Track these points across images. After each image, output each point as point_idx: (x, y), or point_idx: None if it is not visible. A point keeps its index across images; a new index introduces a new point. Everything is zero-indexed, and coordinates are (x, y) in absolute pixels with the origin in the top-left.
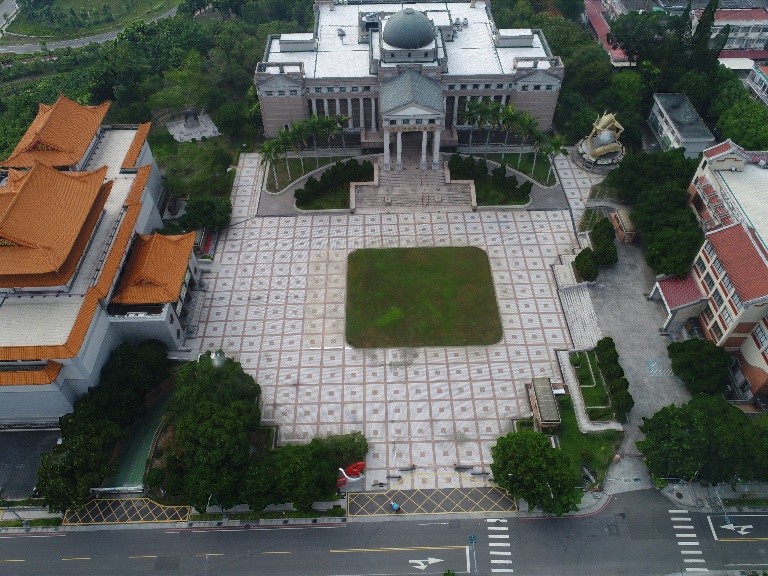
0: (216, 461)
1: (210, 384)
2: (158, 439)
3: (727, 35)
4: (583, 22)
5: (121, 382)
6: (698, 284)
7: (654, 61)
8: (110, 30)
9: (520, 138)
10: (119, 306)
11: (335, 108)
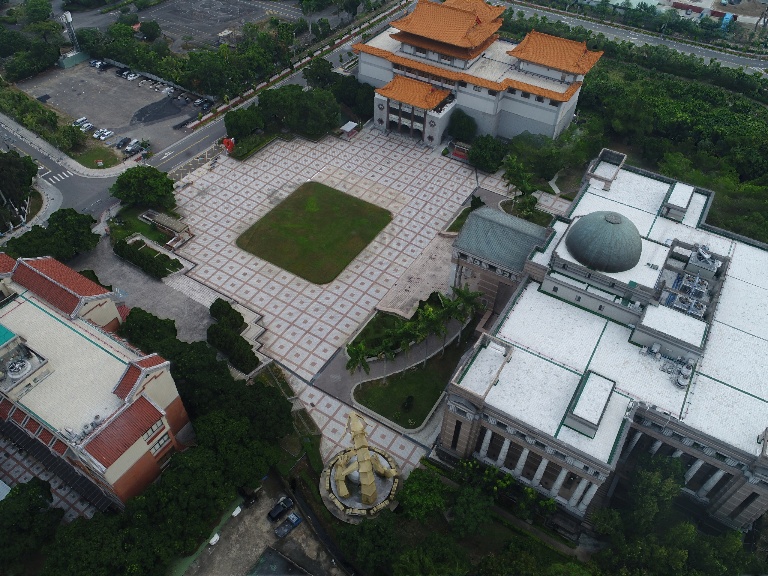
0: None
1: None
2: None
3: None
4: None
5: None
6: None
7: None
8: None
9: None
10: None
11: None
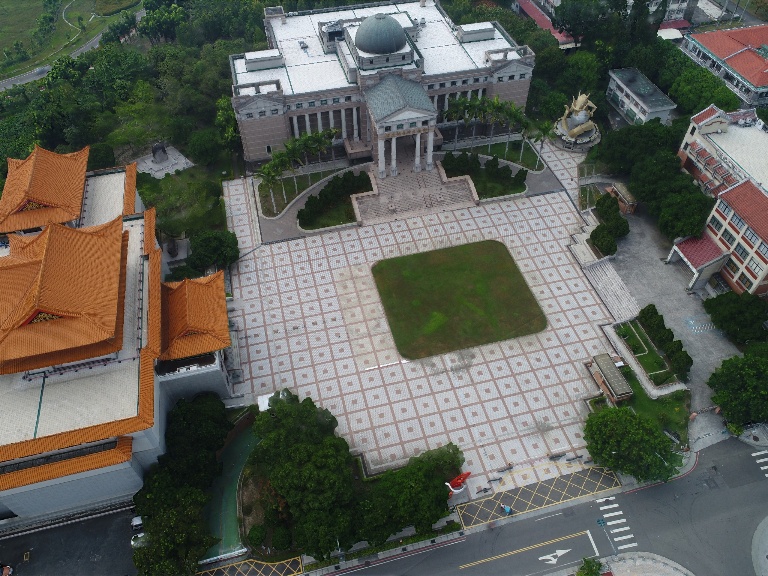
0: (328, 504)
1: (294, 426)
2: (242, 495)
3: (665, 9)
4: (514, 10)
5: (193, 443)
6: (716, 241)
7: (601, 40)
8: (28, 70)
9: (497, 128)
10: (163, 363)
11: (315, 122)
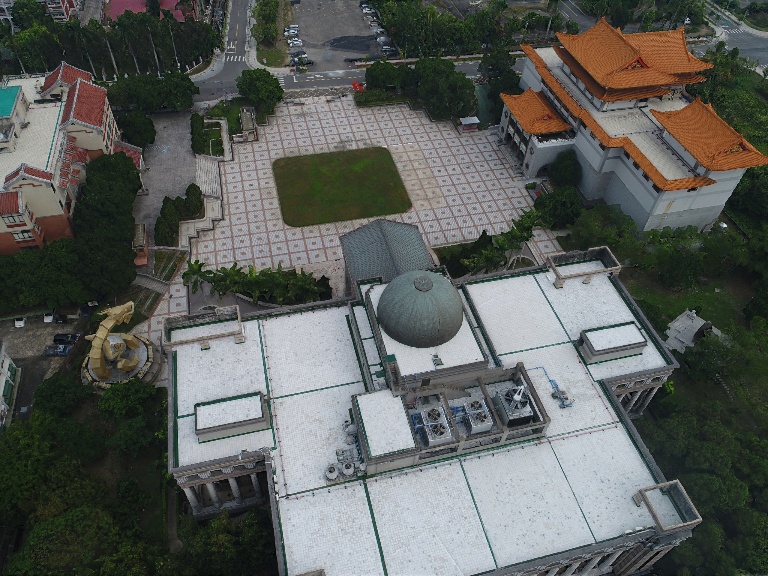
0: None
1: None
2: None
3: None
4: None
5: None
6: None
7: None
8: None
9: None
10: None
11: None
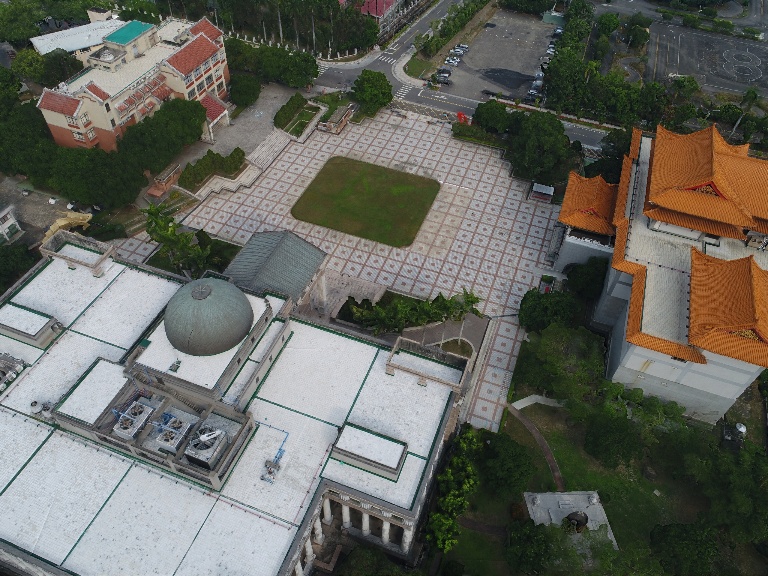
0: None
1: None
2: None
3: None
4: None
5: None
6: (199, 100)
7: None
8: None
9: None
10: None
11: None
